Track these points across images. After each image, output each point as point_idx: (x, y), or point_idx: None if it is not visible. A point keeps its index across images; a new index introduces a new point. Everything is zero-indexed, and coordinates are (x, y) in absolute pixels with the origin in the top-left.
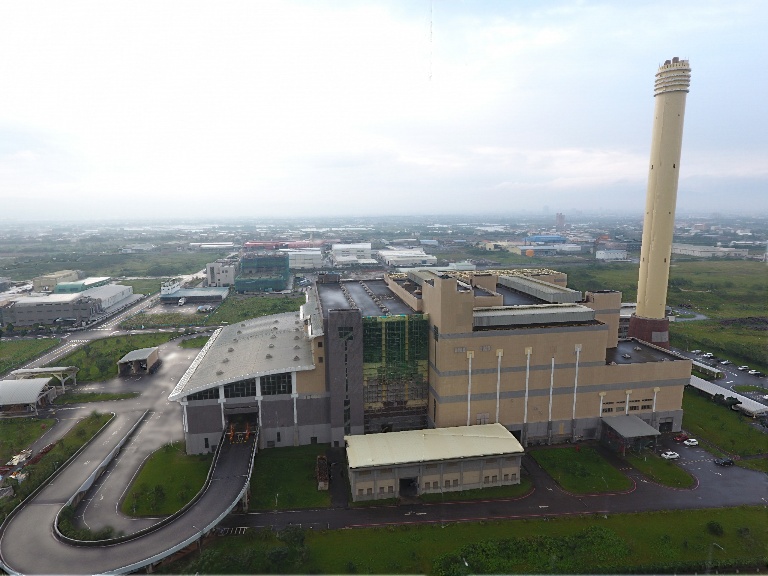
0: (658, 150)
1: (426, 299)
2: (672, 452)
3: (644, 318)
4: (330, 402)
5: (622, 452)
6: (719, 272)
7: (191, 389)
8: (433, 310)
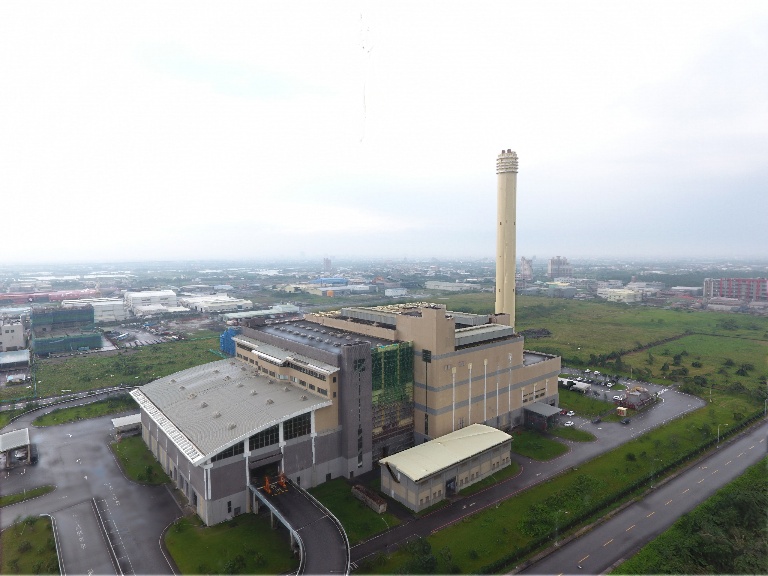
0: (504, 212)
1: (406, 329)
2: None
3: None
4: (346, 434)
5: (545, 428)
6: (478, 301)
7: (218, 448)
8: (421, 337)
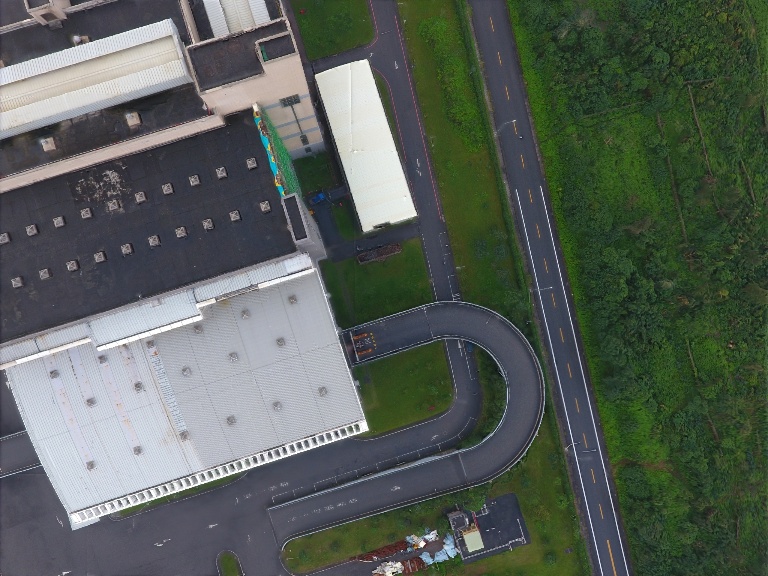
0: None
1: None
2: None
3: None
4: None
5: None
6: None
7: None
8: None
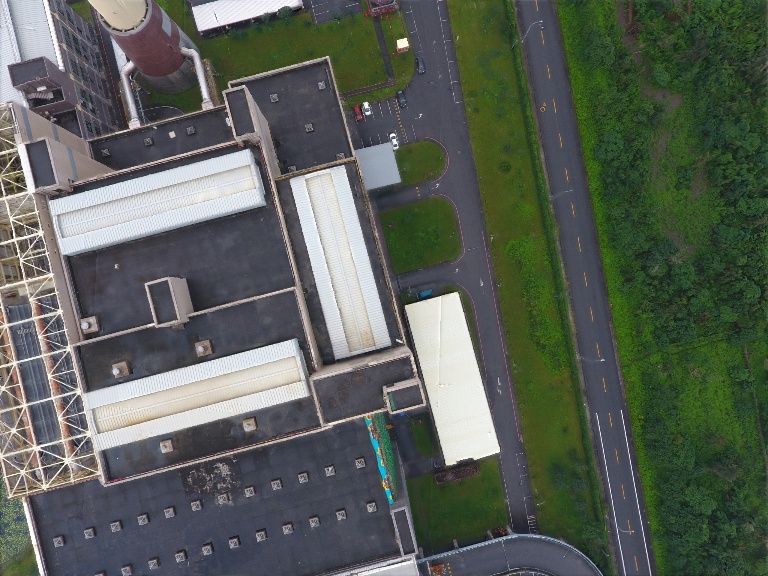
0: None
1: None
2: (393, 139)
3: (144, 26)
4: None
5: None
6: None
7: None
8: None
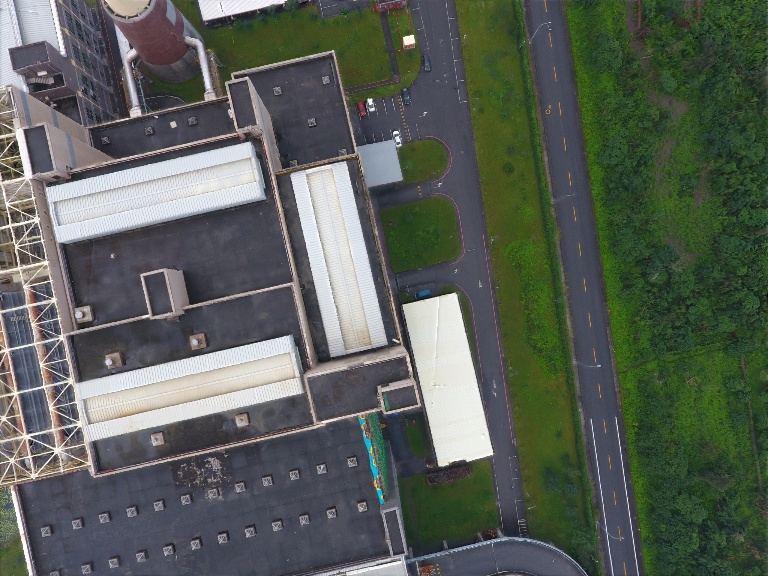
0: None
1: None
2: (396, 136)
3: (147, 13)
4: None
5: None
6: None
7: None
8: None
